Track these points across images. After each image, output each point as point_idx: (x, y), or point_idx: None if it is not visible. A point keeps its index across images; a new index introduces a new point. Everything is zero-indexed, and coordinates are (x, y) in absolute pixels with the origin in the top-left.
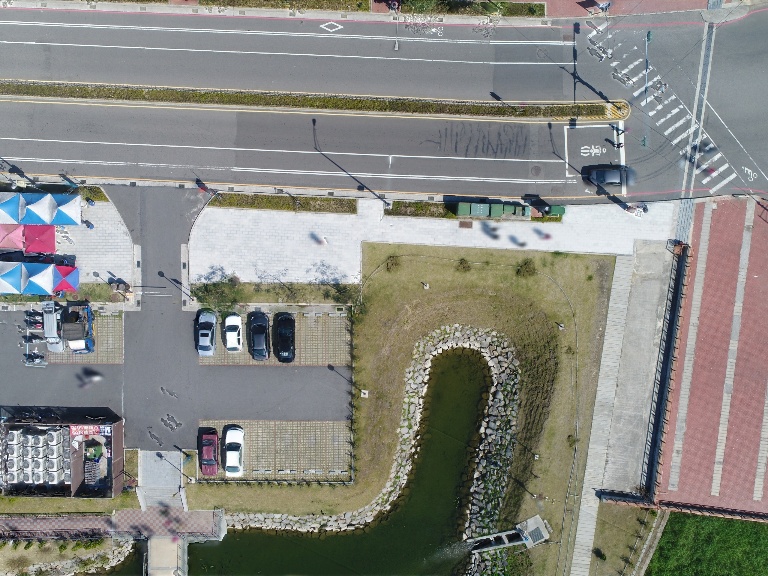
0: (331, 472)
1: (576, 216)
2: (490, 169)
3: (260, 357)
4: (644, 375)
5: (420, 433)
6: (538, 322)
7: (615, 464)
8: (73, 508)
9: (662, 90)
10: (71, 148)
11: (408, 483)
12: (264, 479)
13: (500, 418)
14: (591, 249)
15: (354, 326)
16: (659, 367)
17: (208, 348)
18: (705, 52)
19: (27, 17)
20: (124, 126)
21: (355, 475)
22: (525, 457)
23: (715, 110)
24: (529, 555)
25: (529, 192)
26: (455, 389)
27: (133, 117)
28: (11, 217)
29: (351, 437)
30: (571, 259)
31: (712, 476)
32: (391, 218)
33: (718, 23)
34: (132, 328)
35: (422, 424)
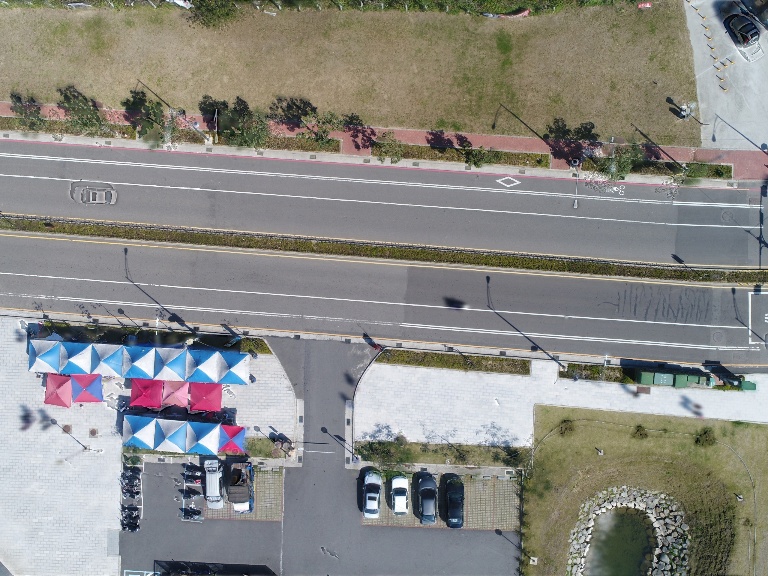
0: None
1: (759, 385)
2: (670, 334)
3: (428, 522)
4: None
5: None
6: (714, 491)
7: None
8: None
9: None
10: (234, 298)
11: None
12: None
13: None
14: None
15: (525, 491)
16: None
17: (375, 511)
18: None
19: (192, 162)
20: (290, 277)
21: None
22: None
23: None
24: None
25: (710, 358)
26: (616, 548)
27: (300, 268)
28: (178, 375)
29: None
30: (752, 429)
31: None
32: (566, 381)
33: None
34: (293, 485)
35: None
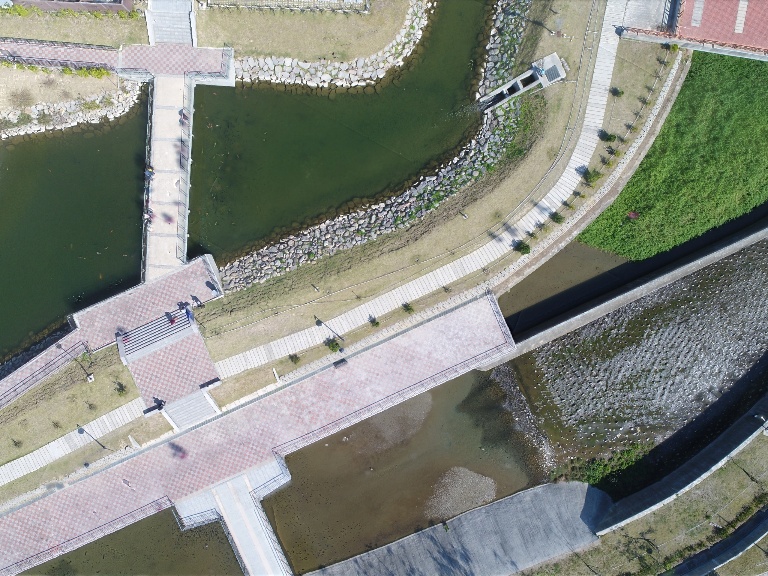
0: None
1: None
2: None
3: None
4: None
5: None
6: None
7: (637, 1)
8: (80, 38)
9: None
10: None
11: (422, 42)
12: (277, 6)
13: None
14: None
15: None
16: None
17: None
18: None
19: None
20: None
21: (370, 4)
22: None
23: None
24: (544, 95)
25: None
26: None
27: None
28: None
29: None
30: None
31: (736, 13)
32: None
33: None
34: None
35: None
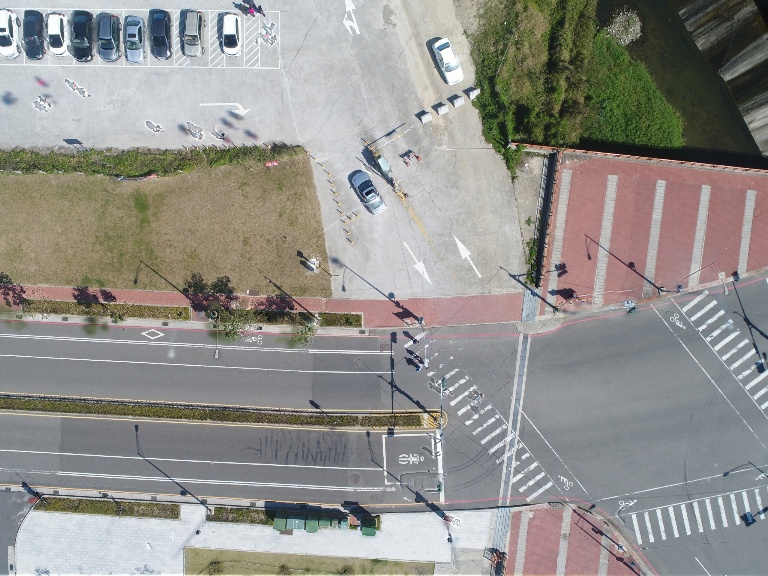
0: None
1: (394, 524)
2: (310, 476)
3: None
4: None
5: None
6: None
7: None
8: None
9: (478, 400)
10: None
11: None
12: None
13: None
14: (410, 557)
15: None
16: None
17: None
18: (520, 363)
19: None
20: None
21: None
22: None
23: (531, 420)
24: None
25: (348, 499)
26: None
27: None
28: None
29: None
30: (390, 566)
31: None
32: (213, 524)
33: (532, 334)
34: None
35: None
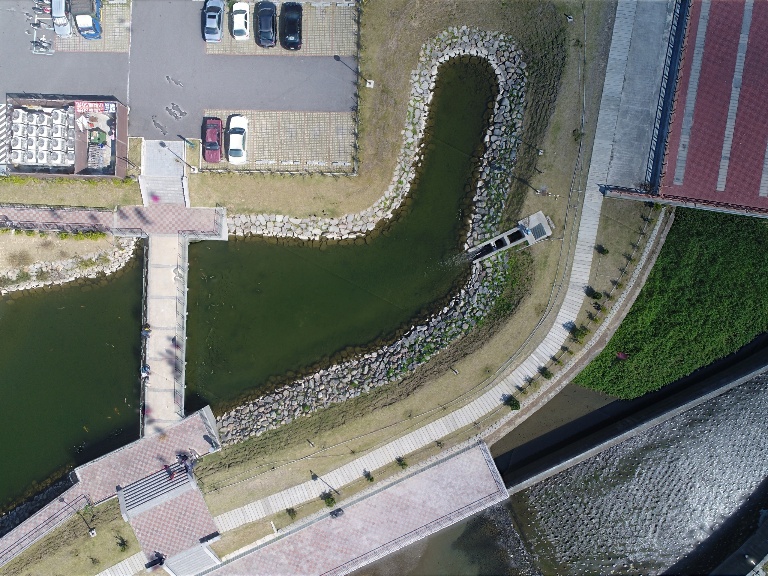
0: (334, 163)
1: None
2: None
3: (266, 41)
4: (652, 70)
5: (424, 142)
6: (547, 16)
7: (620, 160)
8: (75, 201)
9: None
10: None
11: (411, 193)
12: (267, 170)
13: (505, 123)
14: None
15: (361, 15)
16: (668, 62)
17: (215, 31)
18: None
19: None
20: None
21: (358, 166)
22: (529, 155)
23: None
24: (531, 252)
25: None
26: (461, 100)
27: None
28: None
29: (355, 128)
30: None
31: (718, 171)
32: None
33: None
34: (140, 17)
35: (427, 133)
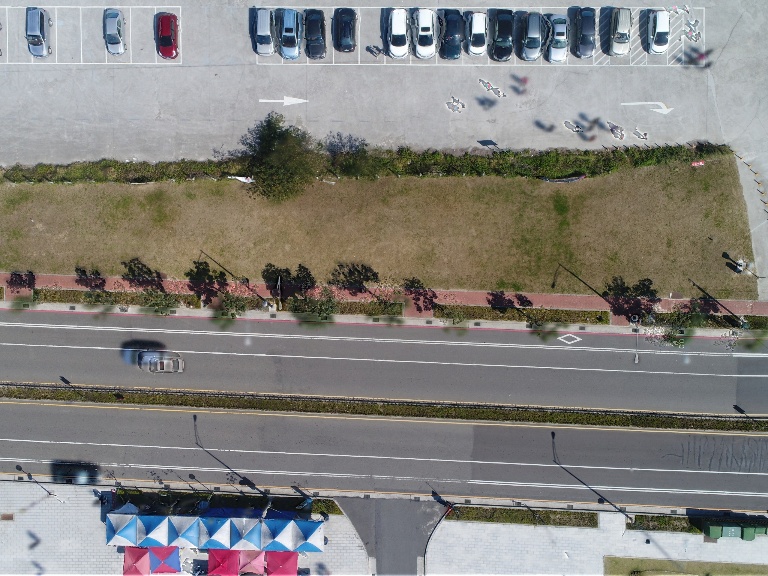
0: None
1: None
2: (734, 483)
3: None
4: None
5: None
6: None
7: None
8: None
9: None
10: (303, 460)
11: None
12: None
13: None
14: None
15: None
16: None
17: None
18: None
19: (257, 329)
20: (358, 438)
21: None
22: None
23: None
24: None
25: None
26: None
27: (367, 430)
28: (254, 545)
29: None
30: None
31: None
32: (633, 532)
33: None
34: None
35: None
